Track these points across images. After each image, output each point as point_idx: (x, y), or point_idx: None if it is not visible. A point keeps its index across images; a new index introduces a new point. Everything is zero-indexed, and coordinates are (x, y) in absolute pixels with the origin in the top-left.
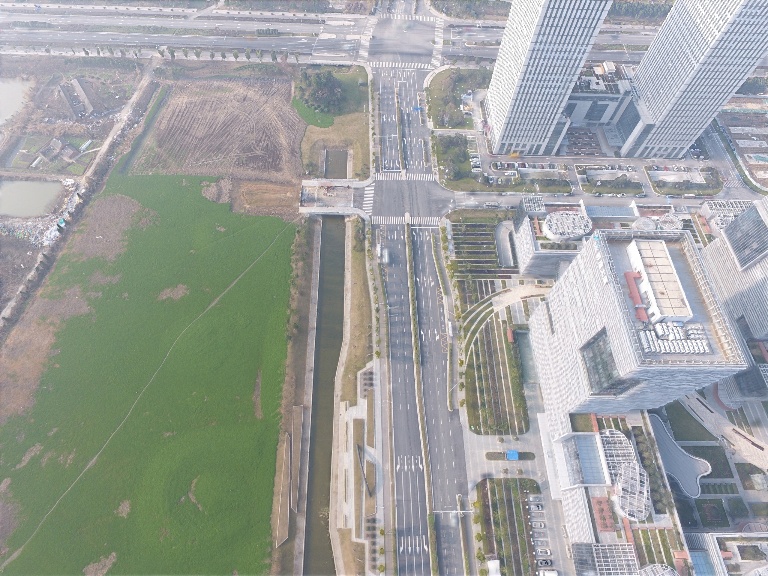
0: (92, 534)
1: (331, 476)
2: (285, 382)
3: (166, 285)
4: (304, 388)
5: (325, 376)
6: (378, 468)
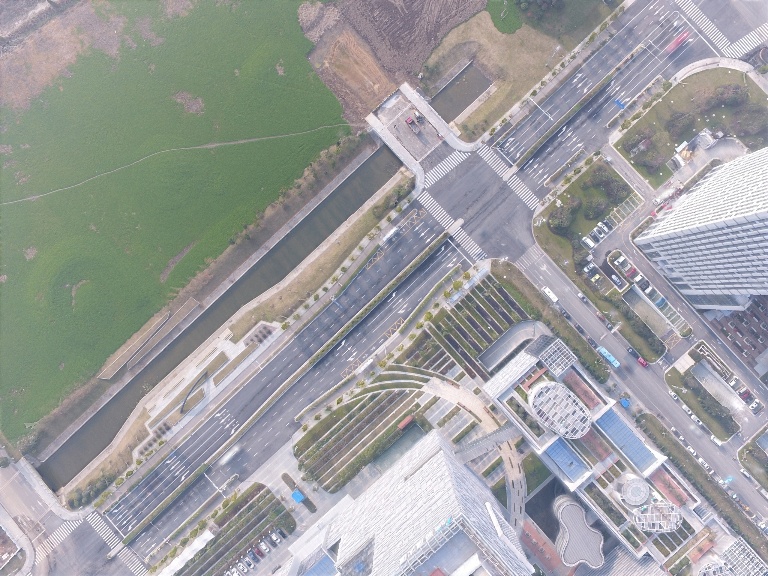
0: (2, 250)
1: (172, 371)
2: (202, 273)
3: (189, 88)
4: (213, 290)
5: (239, 296)
6: (204, 401)
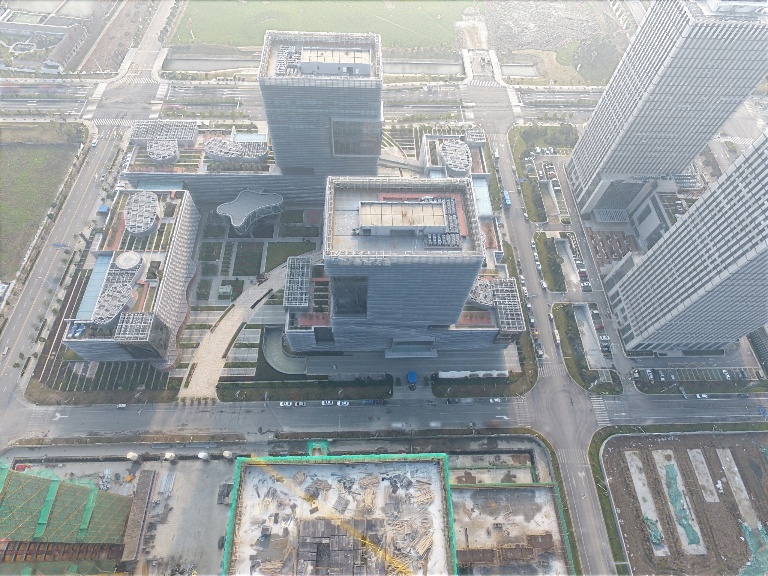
0: None
1: None
2: None
3: (394, 1)
4: None
5: None
6: None
